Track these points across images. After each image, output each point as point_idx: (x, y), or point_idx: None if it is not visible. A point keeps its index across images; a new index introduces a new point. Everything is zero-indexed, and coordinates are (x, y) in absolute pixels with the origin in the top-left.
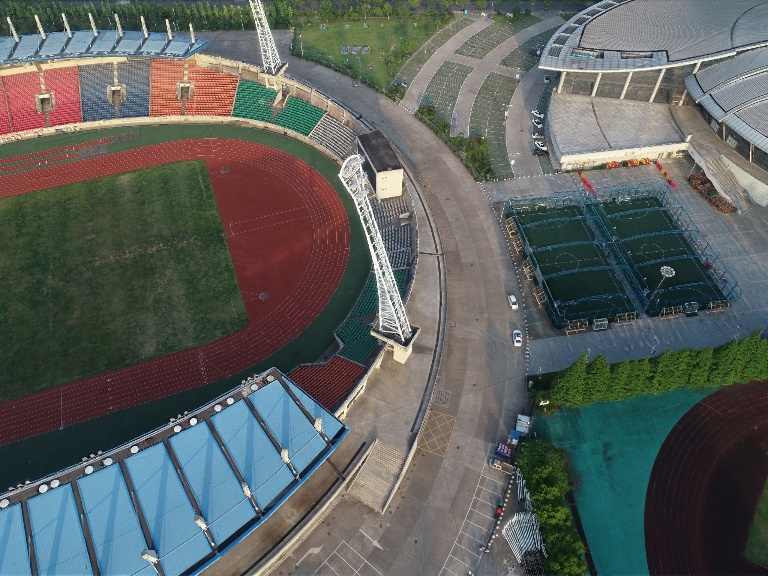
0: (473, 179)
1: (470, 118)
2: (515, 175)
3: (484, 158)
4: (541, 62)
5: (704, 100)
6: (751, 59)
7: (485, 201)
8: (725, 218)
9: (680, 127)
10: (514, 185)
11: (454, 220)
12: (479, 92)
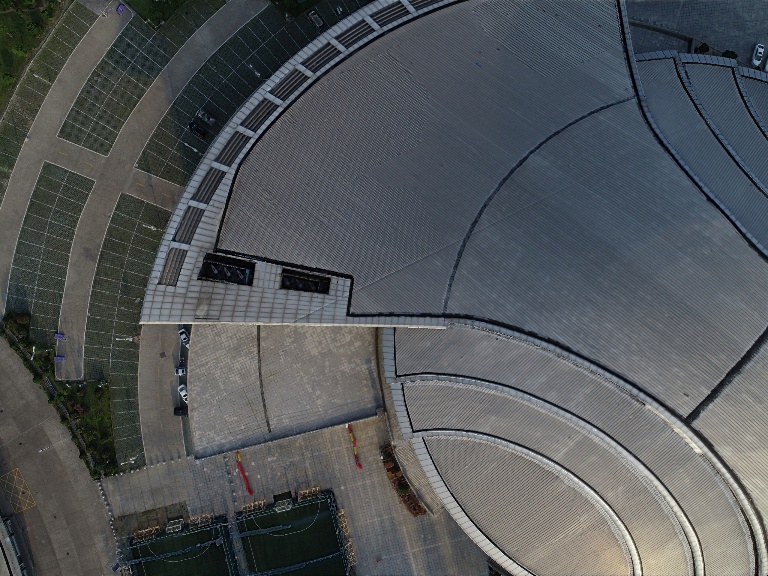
0: (88, 473)
1: (85, 330)
2: (147, 460)
3: (103, 430)
4: (143, 311)
5: (393, 390)
6: (464, 349)
7: (104, 516)
8: (412, 524)
9: (381, 372)
10: (144, 481)
11: (63, 556)
12: (101, 256)
